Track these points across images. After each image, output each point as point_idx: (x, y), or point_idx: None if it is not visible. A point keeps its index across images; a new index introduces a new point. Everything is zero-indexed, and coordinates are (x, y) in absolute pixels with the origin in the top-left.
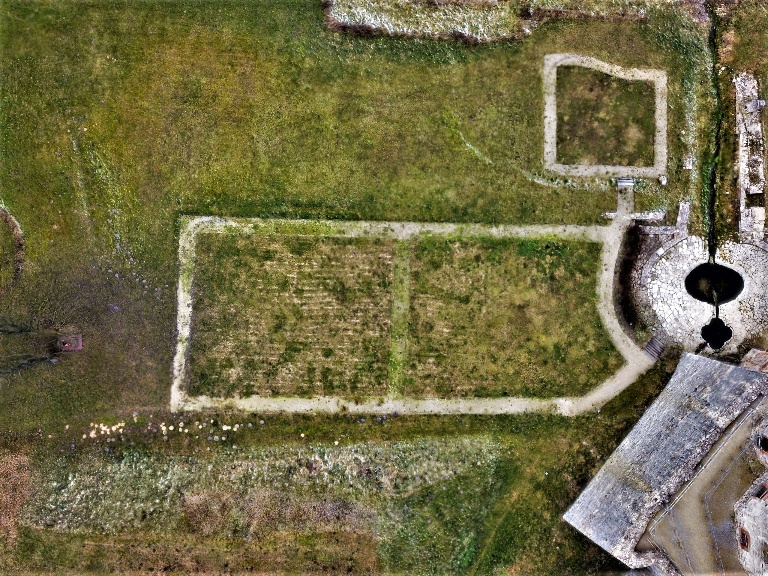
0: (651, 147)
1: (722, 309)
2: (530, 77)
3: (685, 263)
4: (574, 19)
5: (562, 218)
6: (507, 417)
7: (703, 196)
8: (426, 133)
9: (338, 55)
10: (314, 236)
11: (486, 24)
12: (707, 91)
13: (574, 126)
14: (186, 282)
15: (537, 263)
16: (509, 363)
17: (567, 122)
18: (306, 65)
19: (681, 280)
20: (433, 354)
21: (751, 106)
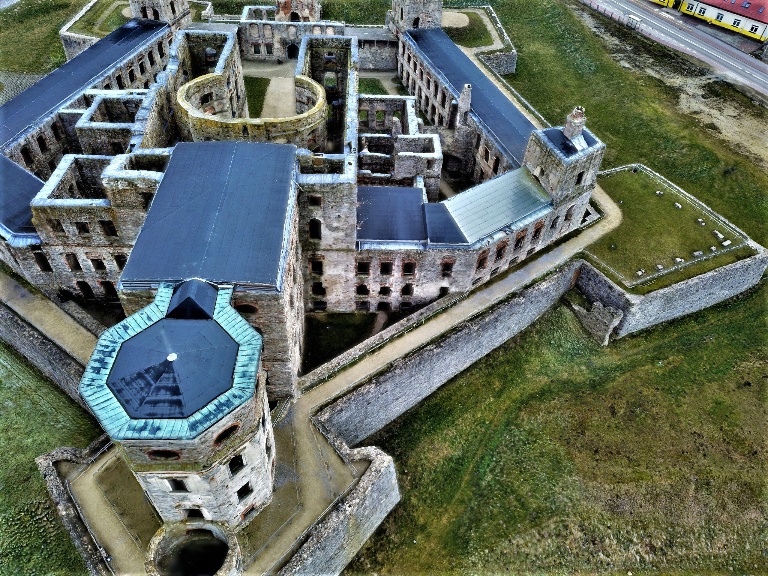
0: None
1: None
2: None
3: None
4: None
5: None
6: None
7: None
8: None
9: None
10: None
11: None
12: None
13: None
14: None
15: None
16: None
17: None
18: None
19: None
20: None
21: None
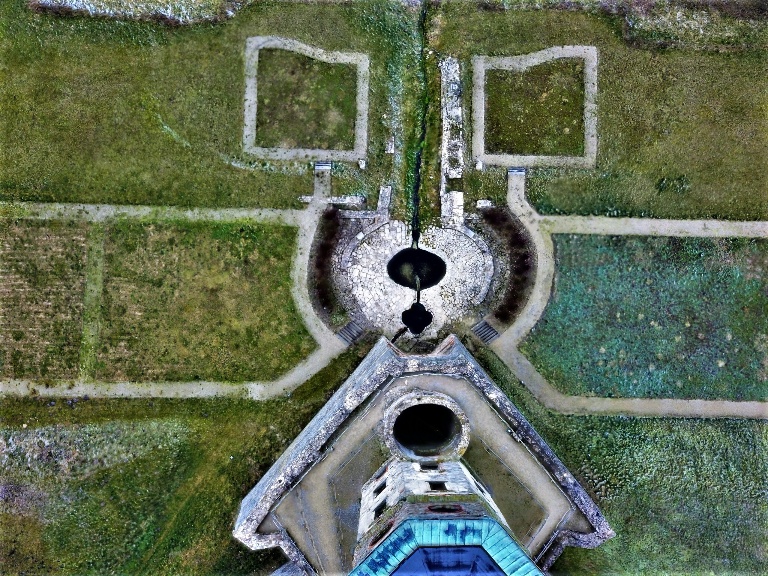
0: (351, 131)
1: (424, 294)
2: (231, 60)
3: (387, 248)
4: (278, 2)
5: (258, 201)
6: (197, 401)
7: (407, 180)
8: (123, 115)
9: (37, 36)
10: (7, 218)
11: (189, 6)
12: (413, 75)
13: (274, 109)
14: None
15: (231, 246)
16: (201, 346)
17: (267, 105)
18: (4, 46)
19: (383, 265)
20: (125, 337)
21: (449, 90)
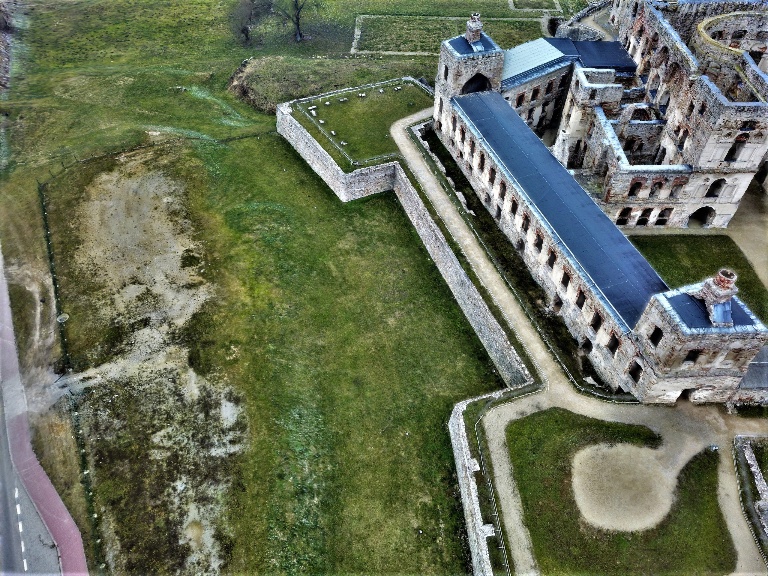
0: (554, 6)
1: None
2: None
3: None
4: None
5: None
6: None
7: None
8: (459, 1)
9: None
10: None
11: None
12: None
13: (520, 2)
14: (359, 27)
15: None
16: None
17: (517, 1)
18: None
19: None
20: None
21: None
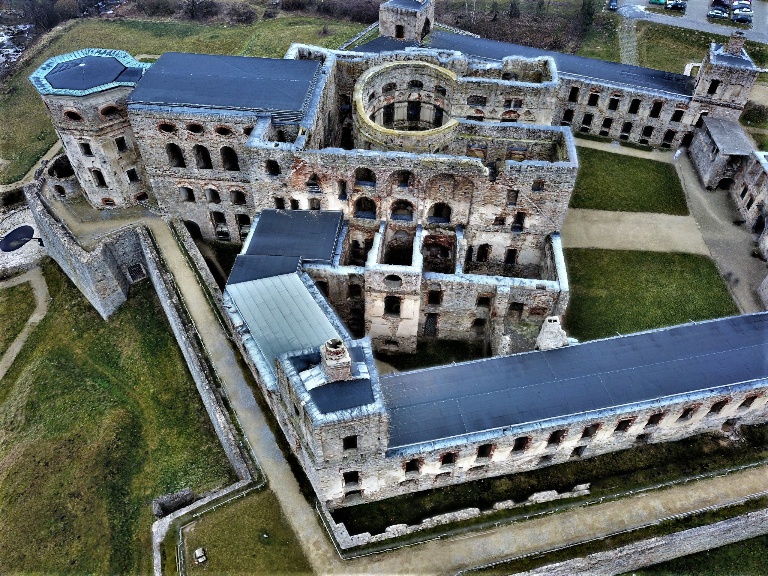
0: None
1: (35, 236)
2: None
3: None
4: None
5: None
6: (20, 353)
7: None
8: None
9: None
10: None
11: None
12: None
13: None
14: None
15: None
16: None
17: None
18: None
19: (1, 253)
20: None
21: None
